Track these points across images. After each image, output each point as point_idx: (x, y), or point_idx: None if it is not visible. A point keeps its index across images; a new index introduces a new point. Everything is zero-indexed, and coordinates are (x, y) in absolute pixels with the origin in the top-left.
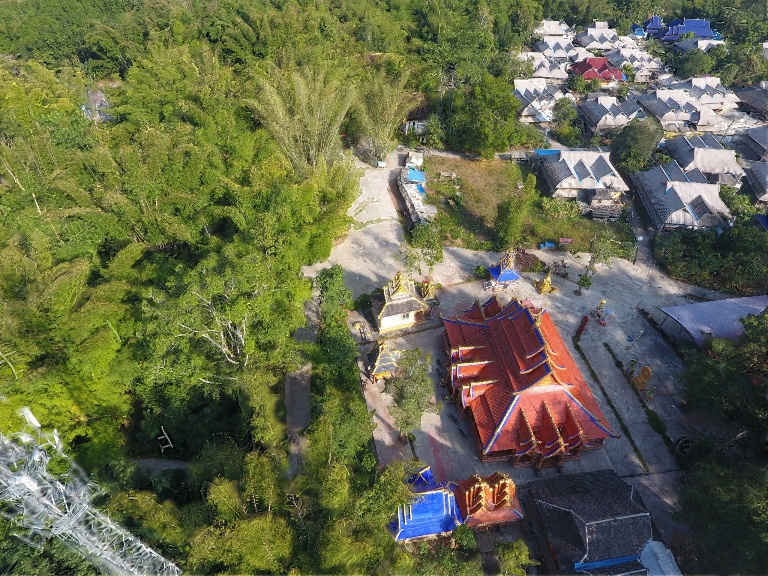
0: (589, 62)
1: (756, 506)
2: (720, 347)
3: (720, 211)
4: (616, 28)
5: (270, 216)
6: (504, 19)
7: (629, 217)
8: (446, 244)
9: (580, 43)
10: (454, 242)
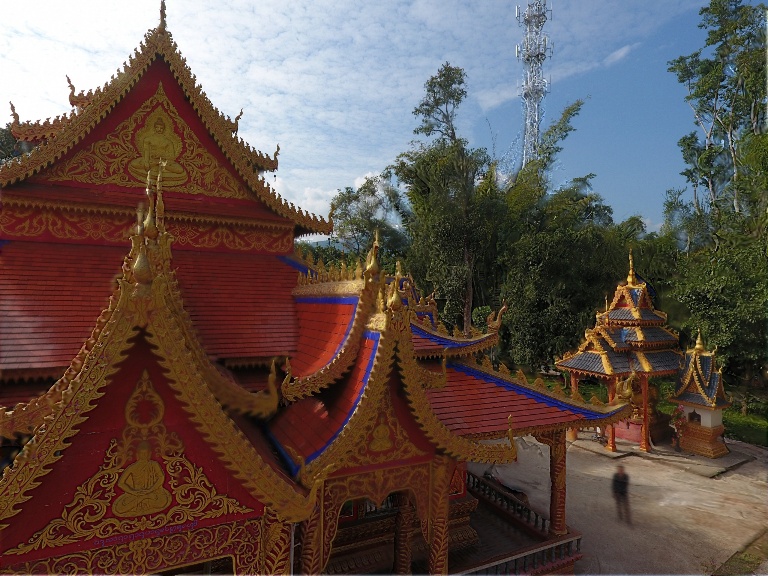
0: None
1: None
2: None
3: None
4: None
5: None
6: None
7: None
8: None
9: None
10: None
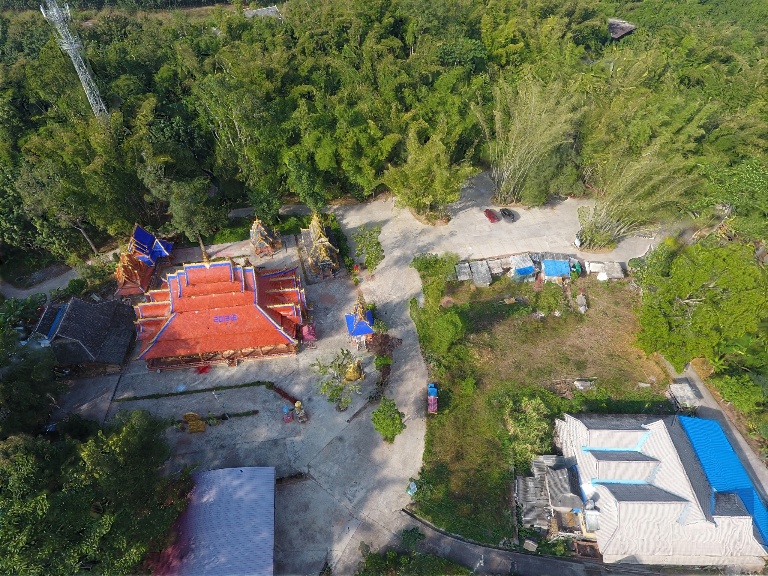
0: None
1: None
2: None
3: None
4: None
5: (303, 104)
6: None
7: None
8: None
9: None
10: None
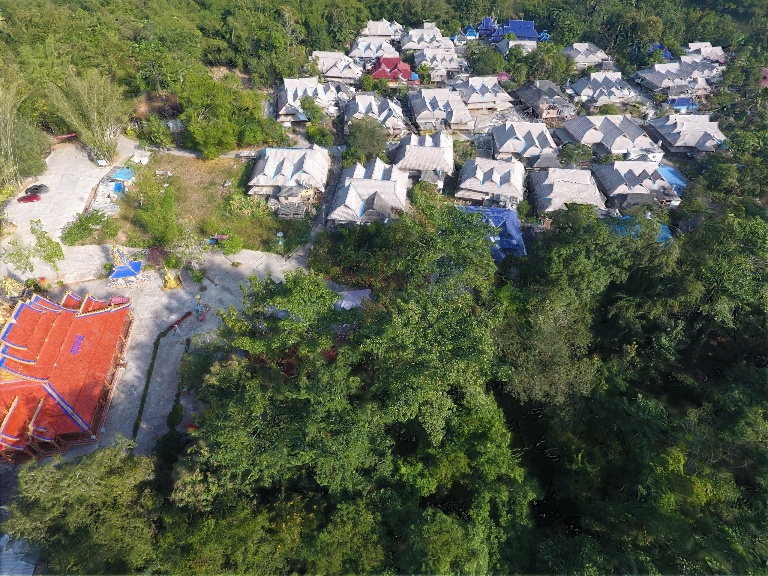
0: (382, 62)
1: (22, 496)
2: (199, 340)
3: (394, 207)
4: (444, 29)
5: None
6: (315, 19)
7: (312, 214)
8: (107, 242)
9: (399, 43)
10: (116, 240)
